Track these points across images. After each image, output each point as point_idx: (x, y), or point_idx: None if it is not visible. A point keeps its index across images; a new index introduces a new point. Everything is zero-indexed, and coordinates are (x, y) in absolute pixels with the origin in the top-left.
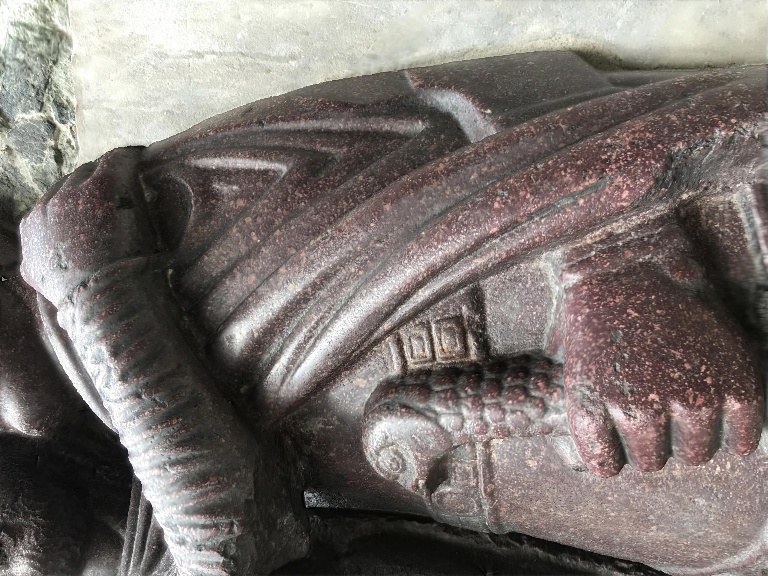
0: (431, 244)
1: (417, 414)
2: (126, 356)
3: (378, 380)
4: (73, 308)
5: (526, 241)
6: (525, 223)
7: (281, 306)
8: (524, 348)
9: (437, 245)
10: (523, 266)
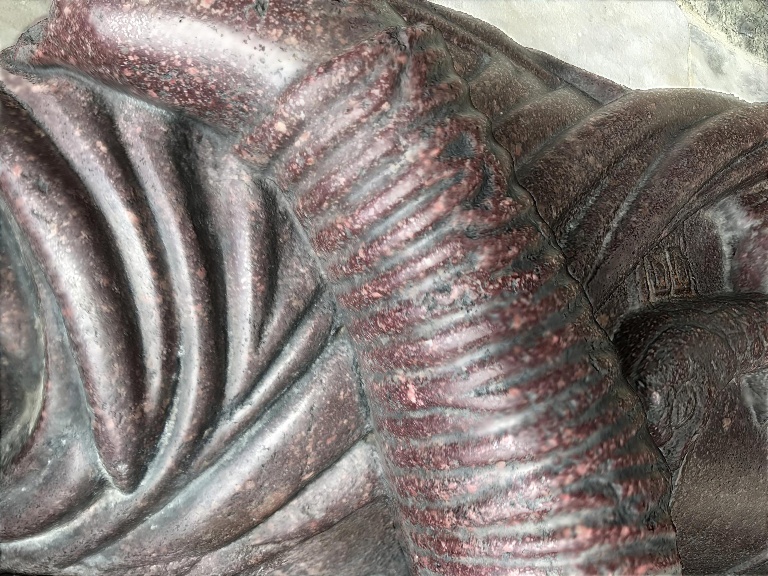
0: (715, 143)
1: (712, 334)
2: (508, 159)
3: (619, 317)
4: (404, 54)
5: (763, 163)
6: (759, 148)
7: (582, 181)
8: (715, 291)
9: (720, 145)
10: (702, 212)
